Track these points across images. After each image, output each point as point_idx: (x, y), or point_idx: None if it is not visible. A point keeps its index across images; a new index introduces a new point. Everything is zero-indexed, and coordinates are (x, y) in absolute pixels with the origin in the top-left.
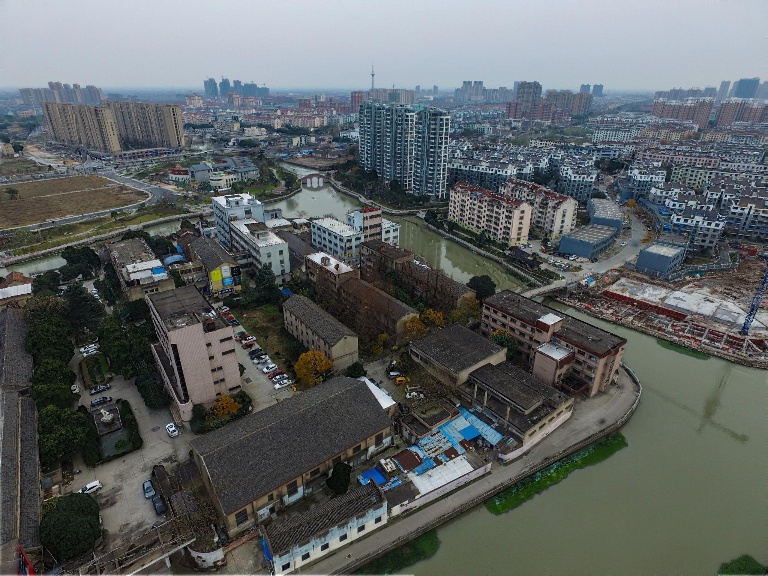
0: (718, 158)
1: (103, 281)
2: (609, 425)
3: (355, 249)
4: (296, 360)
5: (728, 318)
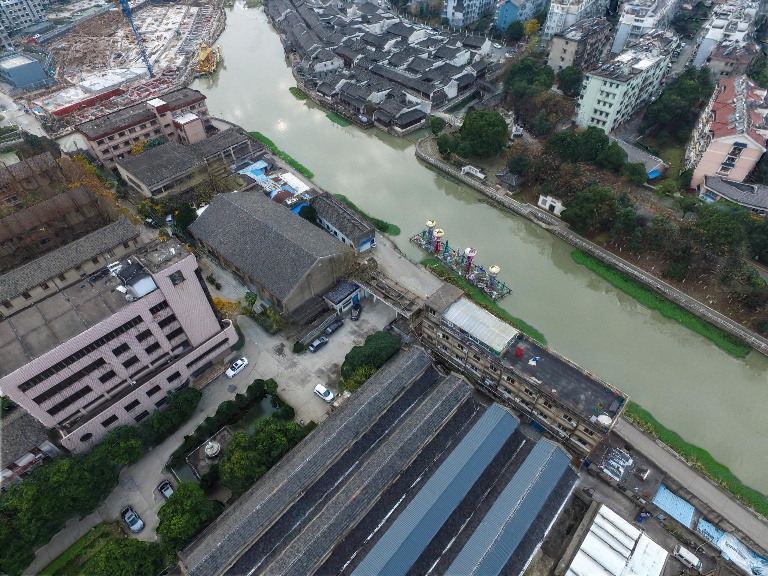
0: None
1: None
2: (244, 132)
3: None
4: None
5: (132, 75)
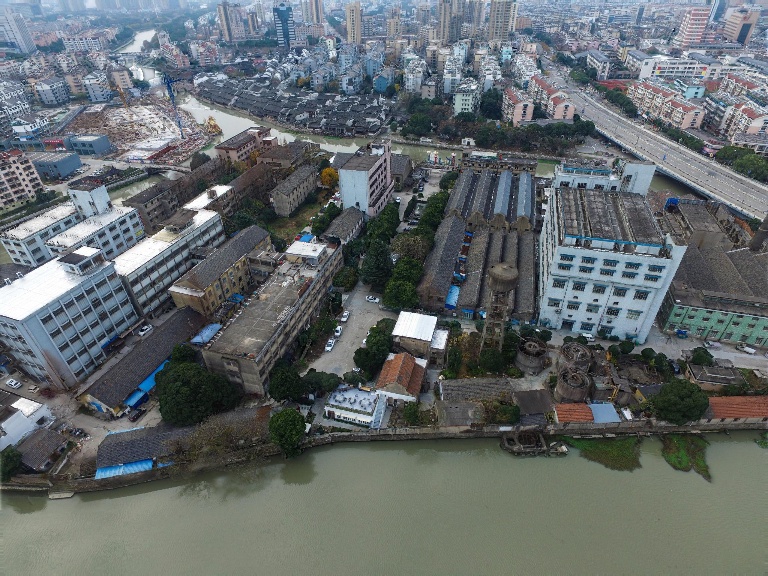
0: None
1: (315, 337)
2: None
3: None
4: (317, 201)
5: (169, 139)
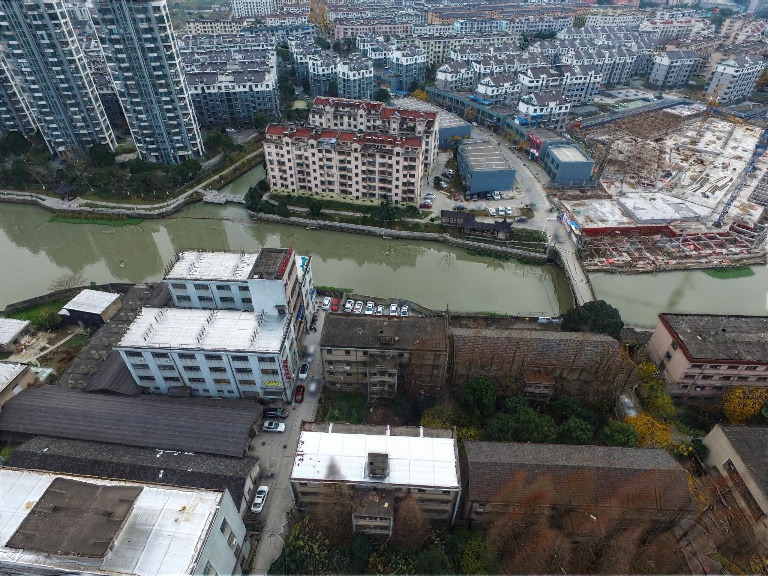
0: (410, 23)
1: None
2: None
3: (289, 355)
4: None
5: (689, 213)
